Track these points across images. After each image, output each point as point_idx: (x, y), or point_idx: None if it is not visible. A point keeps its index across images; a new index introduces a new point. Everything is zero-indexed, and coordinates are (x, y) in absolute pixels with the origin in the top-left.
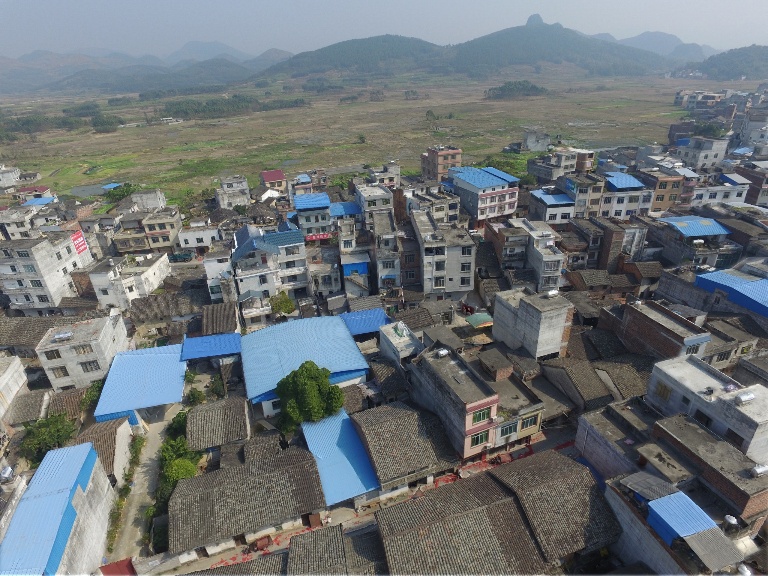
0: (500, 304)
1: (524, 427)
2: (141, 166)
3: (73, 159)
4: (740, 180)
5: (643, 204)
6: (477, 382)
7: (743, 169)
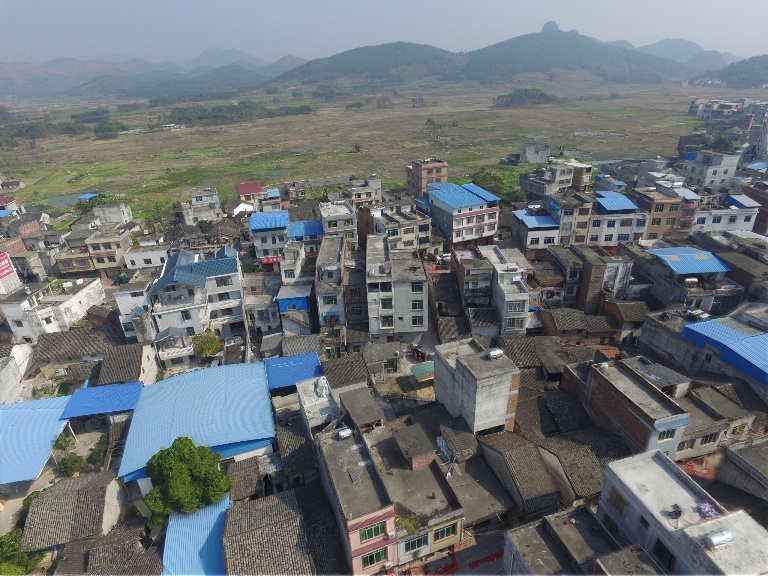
0: (439, 360)
1: (439, 538)
2: (128, 175)
3: (64, 166)
4: (748, 203)
5: (637, 228)
6: (376, 481)
7: (752, 190)
